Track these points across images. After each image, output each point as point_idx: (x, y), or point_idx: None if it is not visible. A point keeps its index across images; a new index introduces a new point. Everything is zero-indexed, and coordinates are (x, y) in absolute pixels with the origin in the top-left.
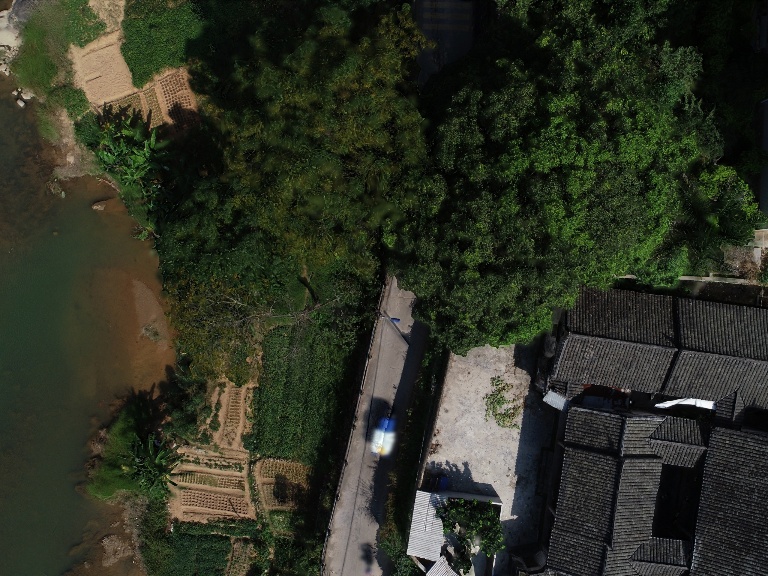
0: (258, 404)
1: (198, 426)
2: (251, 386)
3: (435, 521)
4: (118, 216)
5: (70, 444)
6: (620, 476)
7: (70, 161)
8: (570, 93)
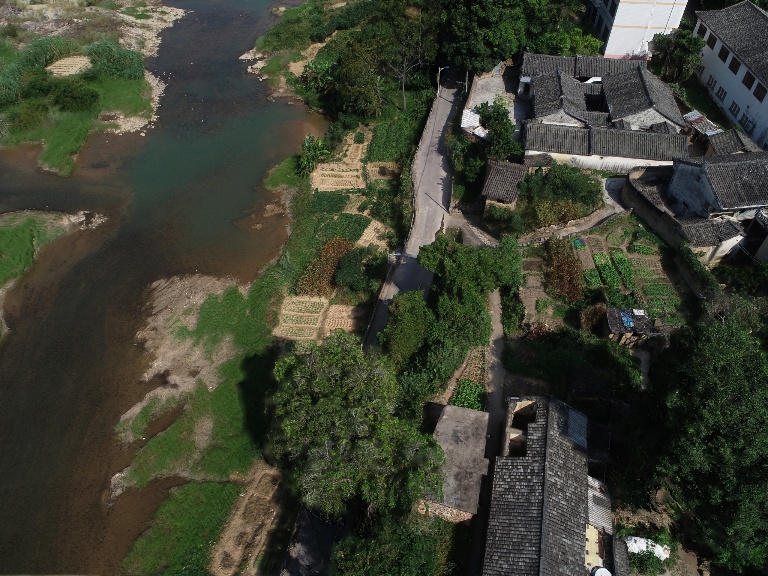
0: (370, 147)
1: (335, 155)
2: (366, 144)
3: (474, 115)
4: (299, 107)
5: (255, 174)
6: (560, 78)
7: (280, 91)
8: None
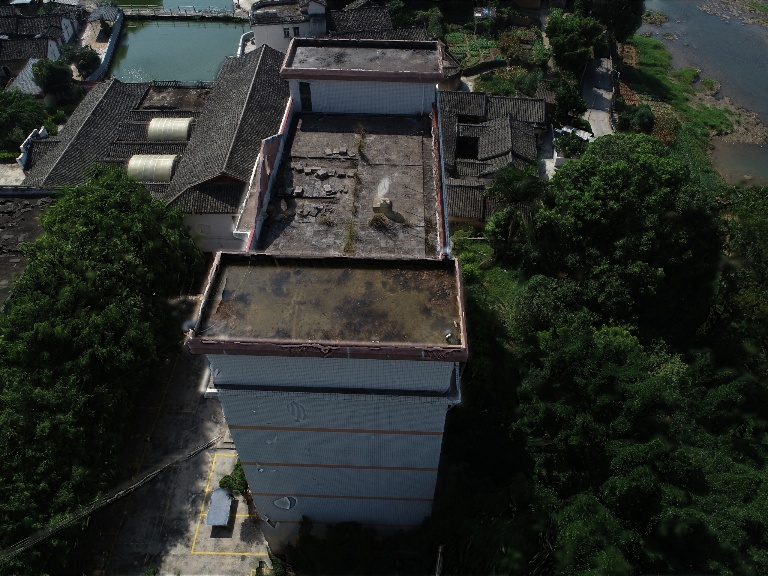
0: None
1: None
2: None
3: None
4: None
5: None
6: None
7: None
8: (648, 215)
